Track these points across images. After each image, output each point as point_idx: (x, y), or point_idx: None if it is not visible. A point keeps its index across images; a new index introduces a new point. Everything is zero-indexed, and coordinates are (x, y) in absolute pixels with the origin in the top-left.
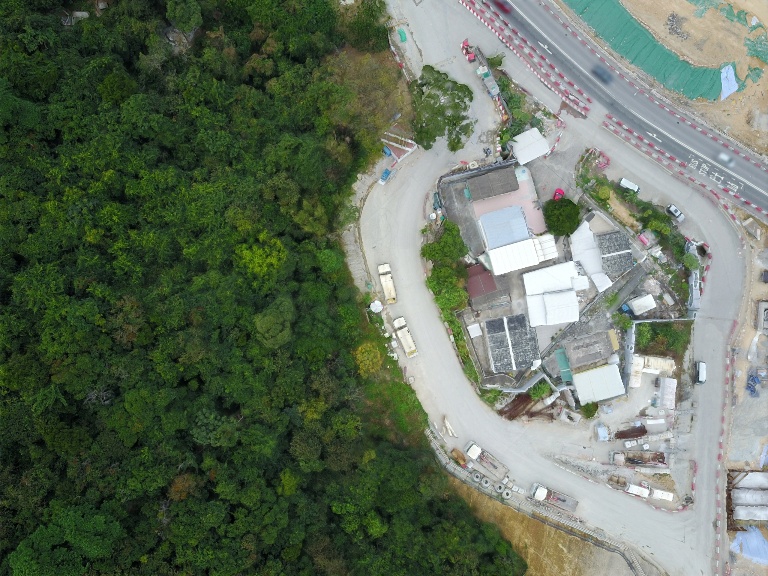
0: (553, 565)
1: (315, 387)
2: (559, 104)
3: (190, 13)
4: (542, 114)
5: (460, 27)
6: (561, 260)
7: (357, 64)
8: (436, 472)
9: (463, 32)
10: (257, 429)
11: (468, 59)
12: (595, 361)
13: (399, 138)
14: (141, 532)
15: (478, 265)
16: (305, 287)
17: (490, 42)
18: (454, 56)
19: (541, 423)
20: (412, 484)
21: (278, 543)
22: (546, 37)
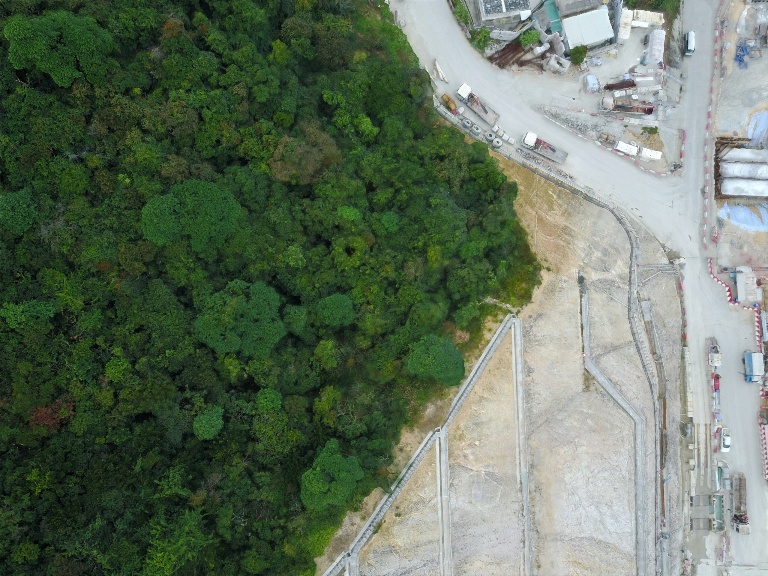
0: (543, 204)
1: None
2: None
3: None
4: None
5: None
6: None
7: None
8: (426, 74)
9: None
10: (248, 2)
11: None
12: (584, 9)
13: None
14: (134, 69)
15: None
16: None
17: None
18: None
19: (531, 74)
20: (403, 88)
21: (270, 108)
22: None
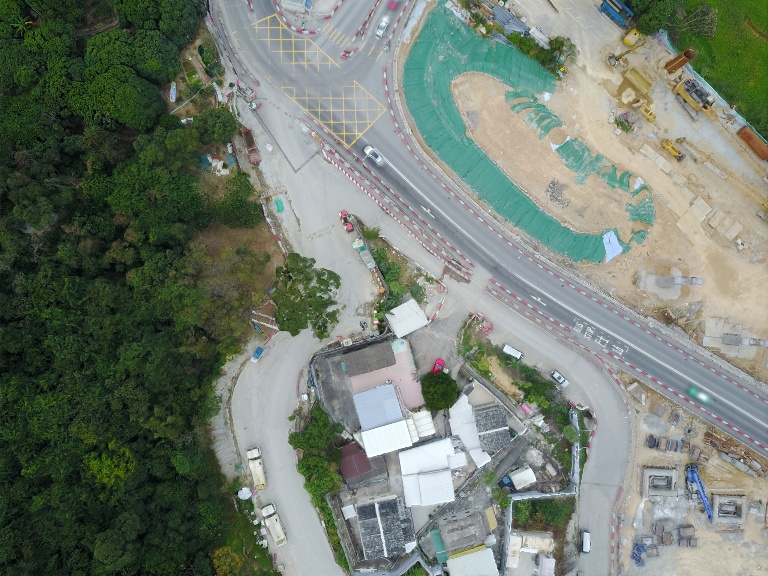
0: None
1: None
2: (442, 269)
3: (40, 213)
4: (424, 279)
5: (339, 194)
6: (441, 433)
7: (217, 258)
8: None
9: (342, 200)
10: None
11: (346, 229)
12: (470, 544)
13: (270, 318)
14: None
15: (353, 444)
16: (160, 491)
17: (370, 209)
18: (332, 225)
19: None
20: None
21: None
22: (429, 201)
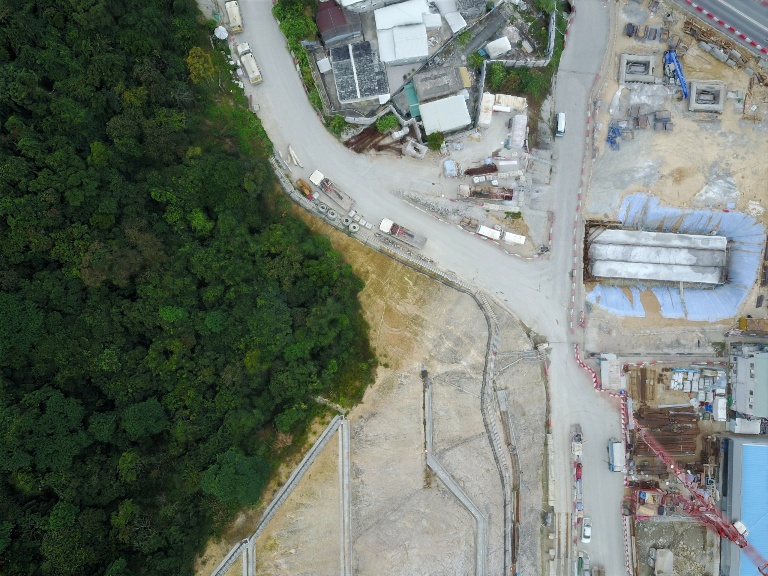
0: (395, 292)
1: (135, 74)
2: None
3: None
4: None
5: None
6: None
7: None
8: (261, 169)
9: None
10: (69, 102)
11: None
12: (443, 94)
13: None
14: None
15: (329, 0)
16: None
17: None
18: None
19: (390, 158)
20: (238, 182)
21: (87, 211)
22: None
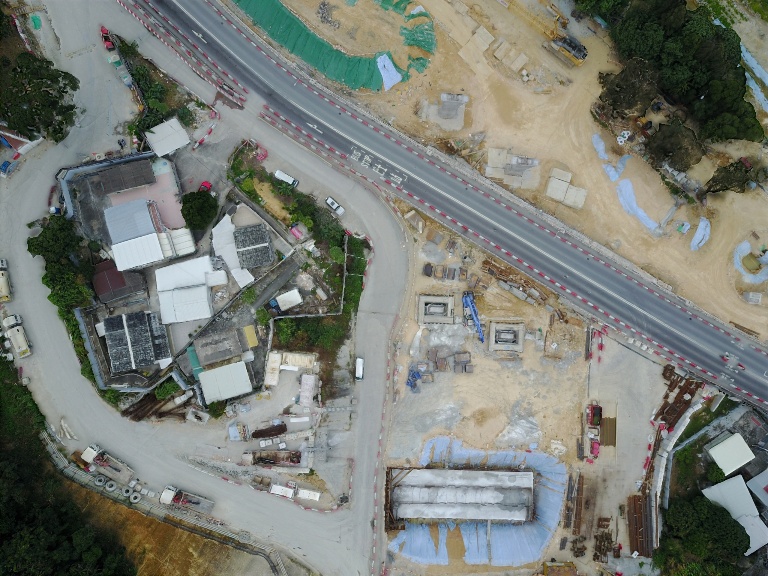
0: (175, 570)
1: None
2: (214, 94)
3: None
4: (195, 105)
5: (103, 15)
6: (205, 255)
7: None
8: (7, 477)
9: (105, 20)
10: None
11: (106, 48)
12: (225, 358)
13: None
14: None
15: (108, 261)
16: None
17: (136, 30)
18: (93, 44)
19: (173, 423)
20: None
21: None
22: (201, 26)
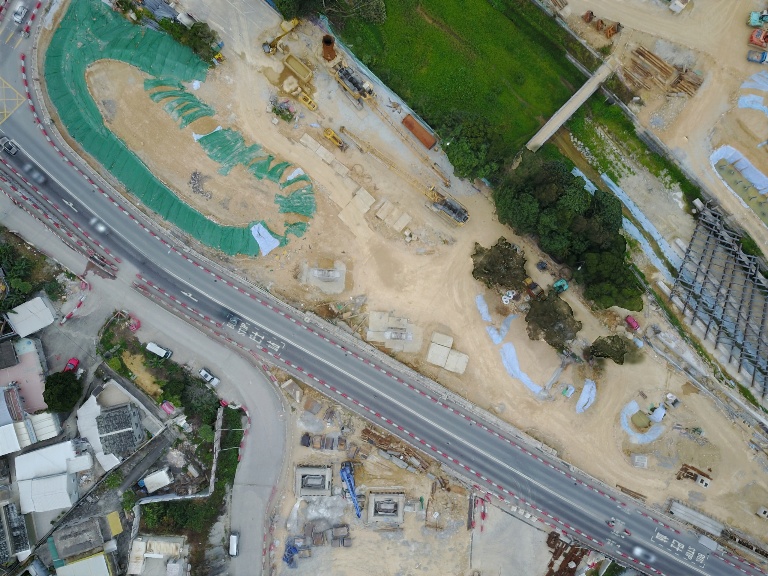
0: None
1: None
2: (85, 265)
3: None
4: (65, 276)
5: None
6: (71, 436)
7: None
8: None
9: None
10: None
11: None
12: (85, 551)
13: None
14: None
15: None
16: None
17: (2, 203)
18: None
19: None
20: None
21: None
22: (71, 194)
